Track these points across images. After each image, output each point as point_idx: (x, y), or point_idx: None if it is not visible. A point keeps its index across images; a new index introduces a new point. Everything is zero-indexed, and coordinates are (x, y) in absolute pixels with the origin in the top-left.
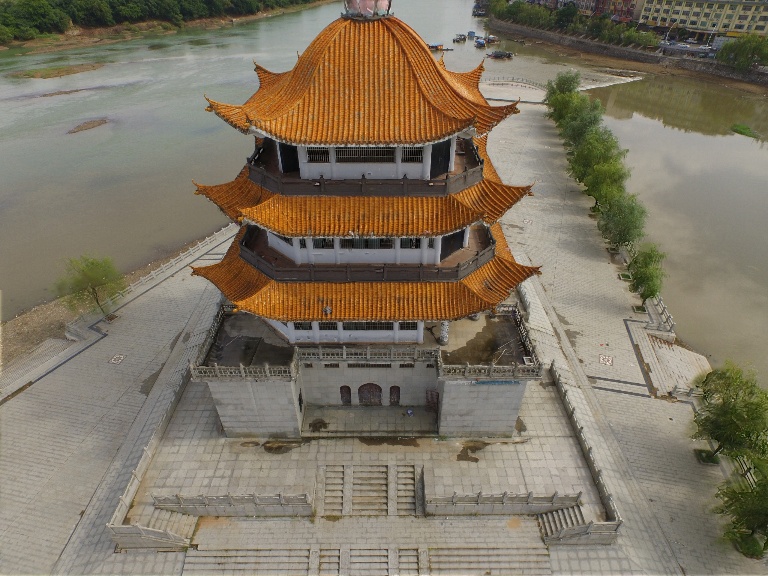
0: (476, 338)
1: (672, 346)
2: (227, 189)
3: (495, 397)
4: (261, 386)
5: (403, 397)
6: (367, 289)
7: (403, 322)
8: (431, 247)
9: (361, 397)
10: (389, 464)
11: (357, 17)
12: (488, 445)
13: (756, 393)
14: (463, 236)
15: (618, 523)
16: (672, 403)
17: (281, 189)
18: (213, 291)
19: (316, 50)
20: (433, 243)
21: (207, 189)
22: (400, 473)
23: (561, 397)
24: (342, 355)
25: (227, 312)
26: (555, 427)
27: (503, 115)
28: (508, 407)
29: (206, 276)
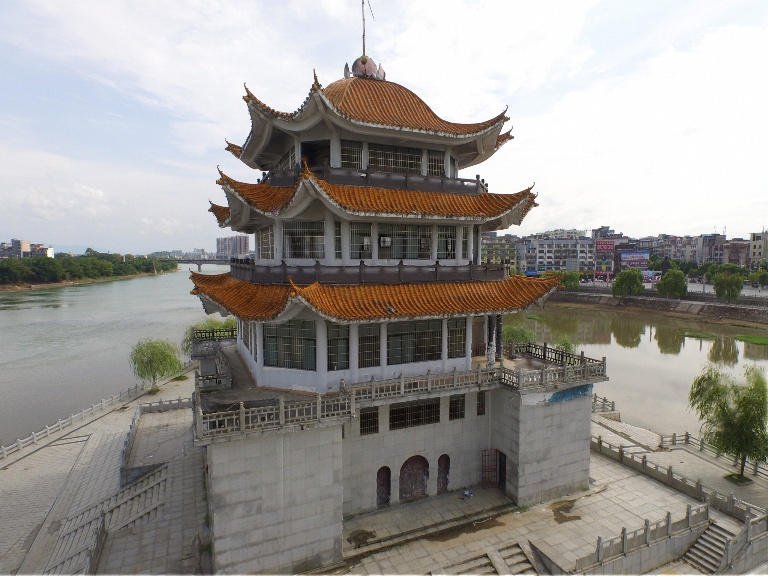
0: (517, 368)
1: (622, 423)
2: (251, 188)
3: (567, 422)
4: (298, 450)
5: (453, 474)
6: (423, 291)
7: (452, 346)
8: (465, 257)
9: (400, 490)
10: (487, 551)
11: (363, 76)
12: (575, 501)
13: (740, 390)
14: (477, 263)
15: (766, 515)
16: (669, 452)
17: (326, 178)
18: (86, 470)
19: (337, 86)
20: (466, 253)
21: (231, 181)
22: (507, 559)
23: (596, 450)
24: (399, 389)
25: (203, 389)
26: (617, 471)
27: (503, 138)
28: (580, 437)
29: (213, 295)
